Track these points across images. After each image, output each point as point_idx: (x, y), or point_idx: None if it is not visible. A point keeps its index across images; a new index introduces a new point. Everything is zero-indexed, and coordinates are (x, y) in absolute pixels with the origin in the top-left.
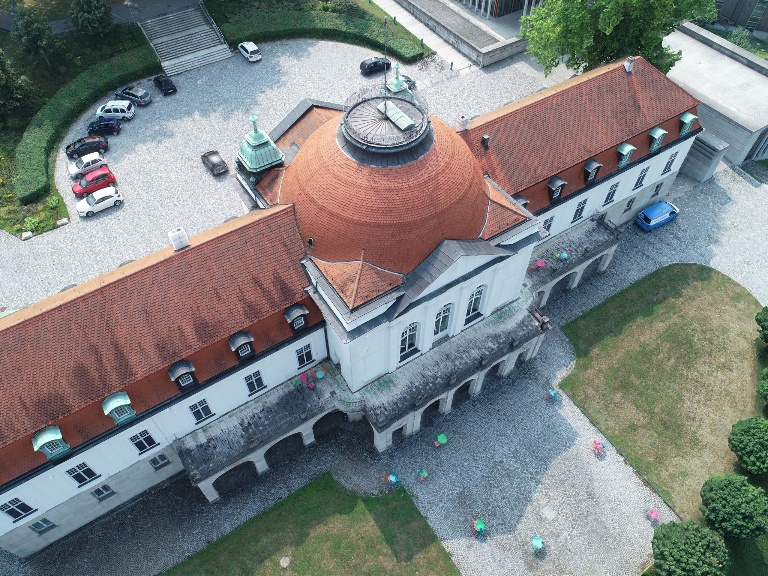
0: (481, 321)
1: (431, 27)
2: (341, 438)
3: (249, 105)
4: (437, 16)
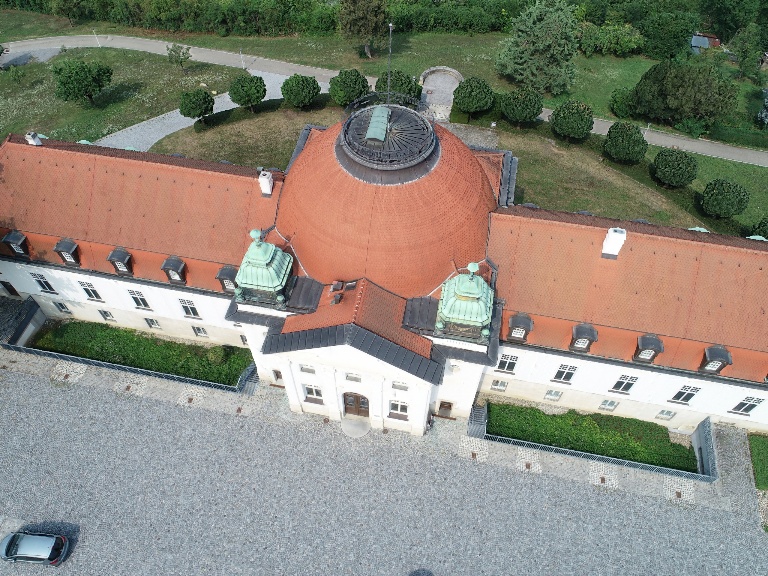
0: None
1: None
2: None
3: None
4: None
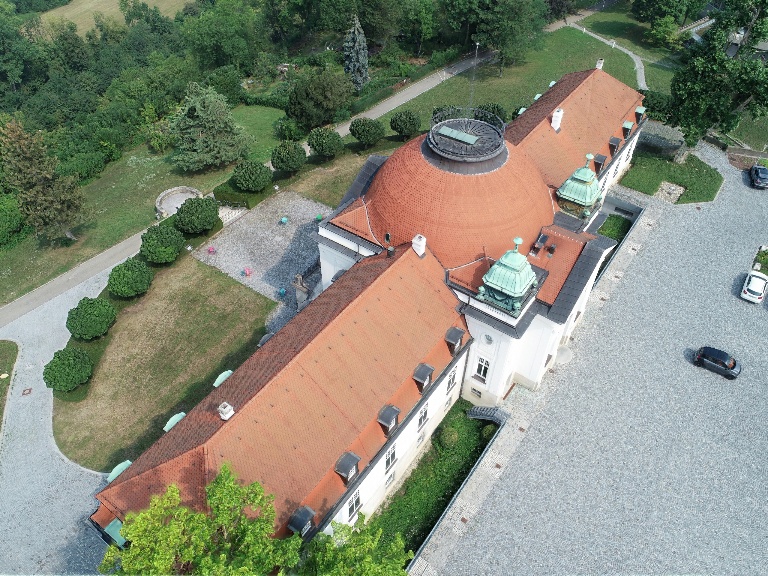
0: None
1: None
2: None
3: None
4: None
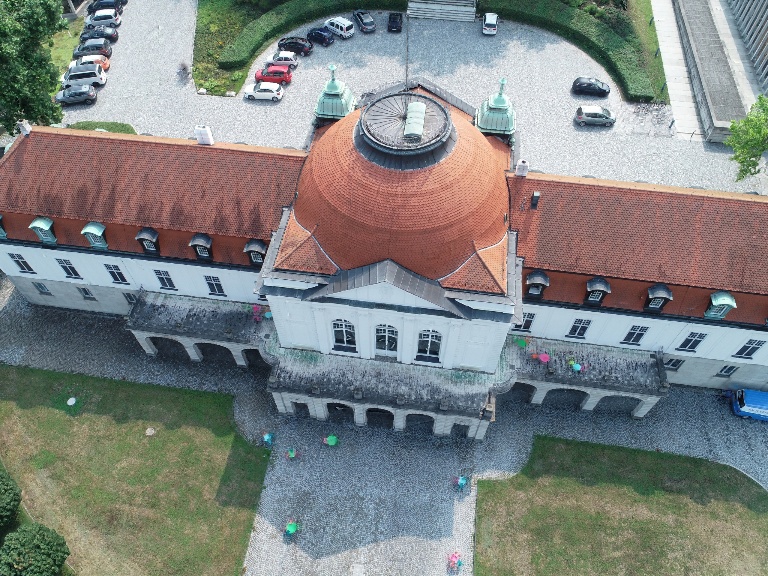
0: (437, 368)
1: (691, 75)
2: (266, 379)
3: (444, 70)
4: (704, 66)
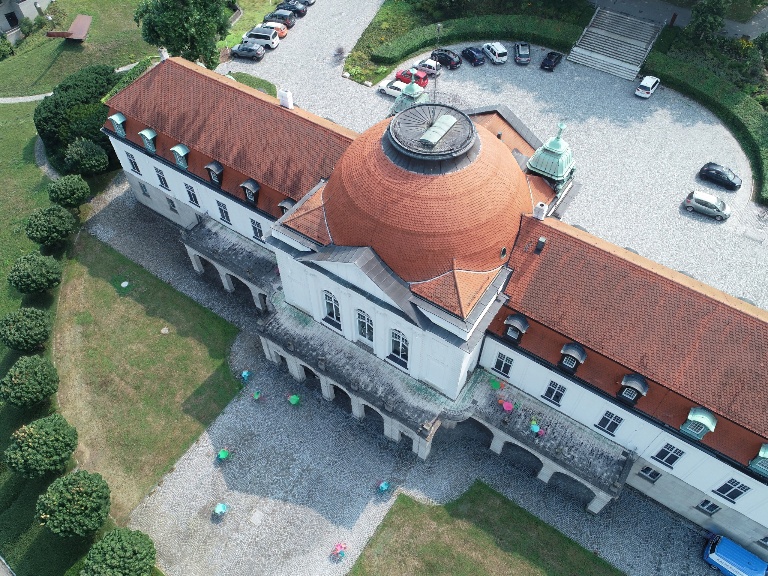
0: (405, 374)
1: None
2: None
3: (574, 117)
4: None
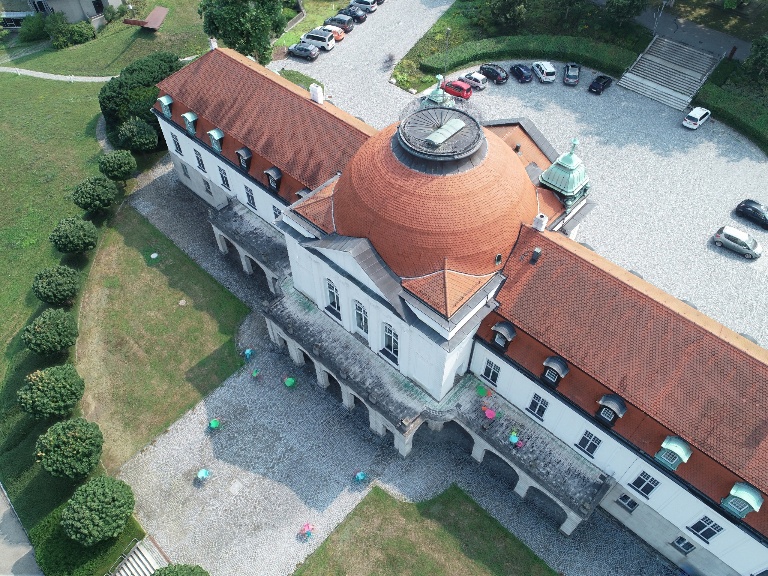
0: (396, 369)
1: None
2: None
3: (614, 142)
4: None
